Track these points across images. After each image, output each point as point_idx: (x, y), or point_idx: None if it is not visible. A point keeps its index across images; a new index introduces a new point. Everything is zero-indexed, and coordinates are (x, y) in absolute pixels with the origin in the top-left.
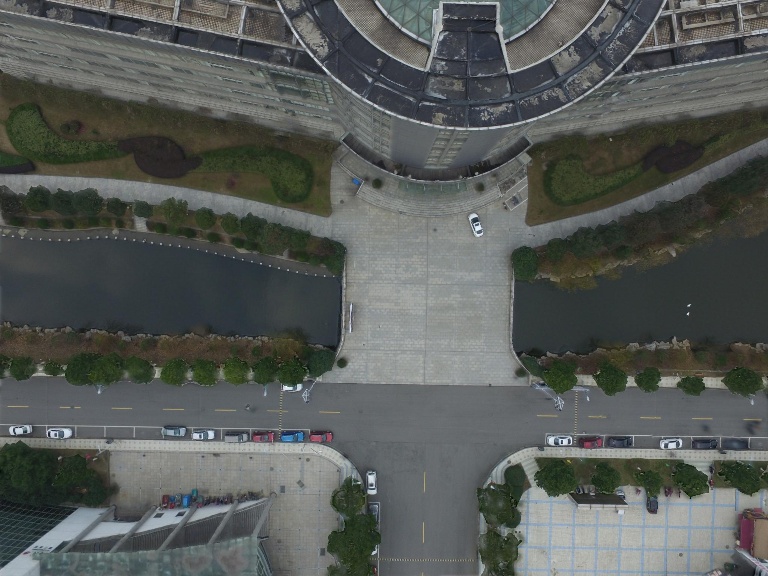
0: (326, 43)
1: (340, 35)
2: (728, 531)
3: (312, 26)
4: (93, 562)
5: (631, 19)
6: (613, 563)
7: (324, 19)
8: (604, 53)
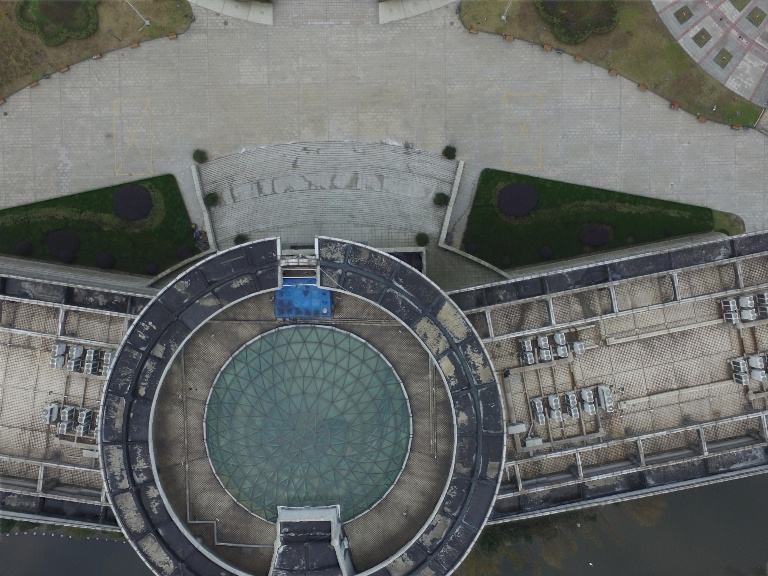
0: (171, 560)
1: (184, 553)
2: None
3: (157, 545)
4: None
5: (460, 525)
6: None
7: (168, 538)
8: (436, 557)
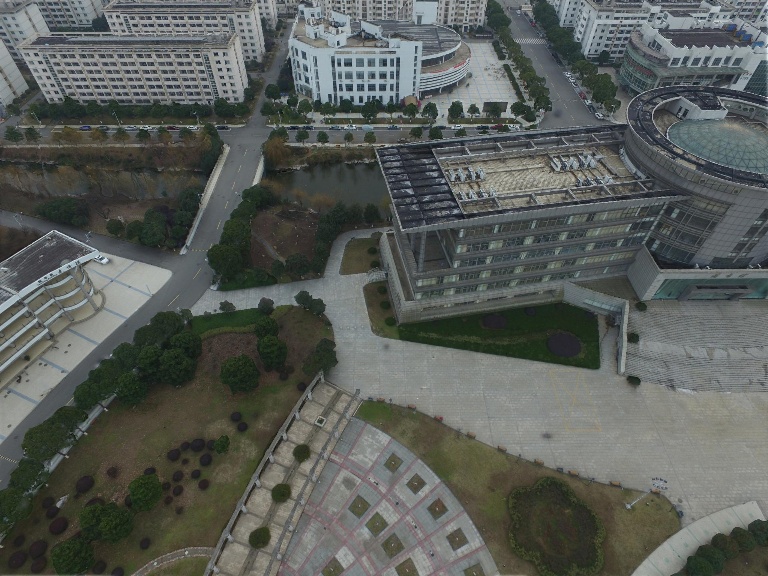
0: None
1: None
2: (422, 108)
3: None
4: (722, 70)
5: None
6: (474, 100)
7: None
8: None
